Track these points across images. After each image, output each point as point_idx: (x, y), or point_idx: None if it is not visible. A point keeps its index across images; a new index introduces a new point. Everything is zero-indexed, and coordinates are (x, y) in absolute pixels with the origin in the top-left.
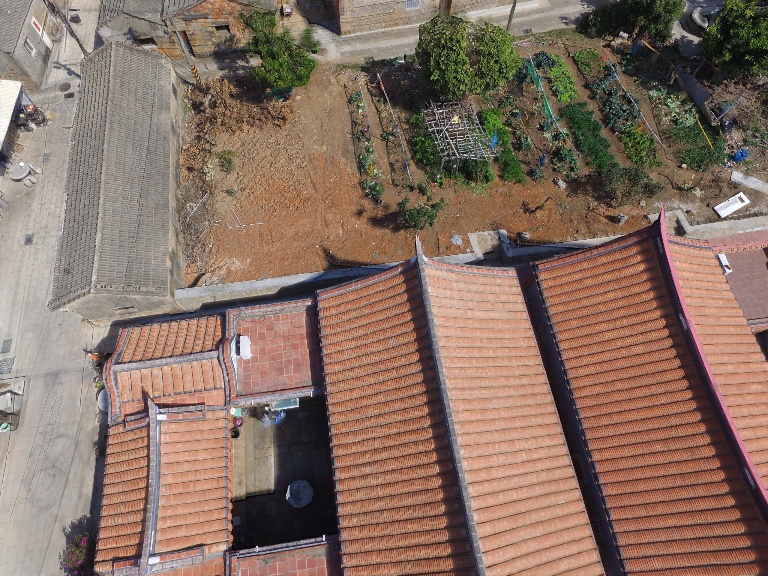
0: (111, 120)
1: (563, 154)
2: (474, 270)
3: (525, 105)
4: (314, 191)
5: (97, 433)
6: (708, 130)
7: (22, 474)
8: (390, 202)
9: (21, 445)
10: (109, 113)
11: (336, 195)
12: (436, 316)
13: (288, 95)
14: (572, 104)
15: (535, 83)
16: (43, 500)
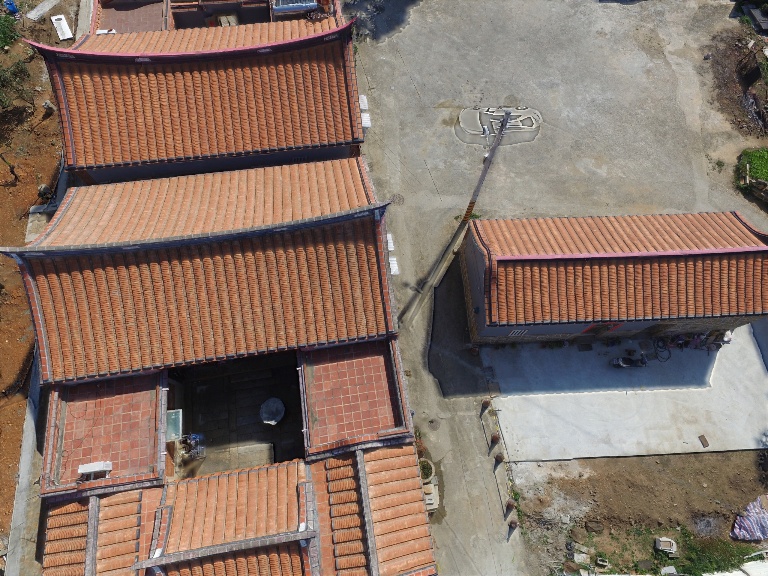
0: None
1: None
2: (56, 217)
3: None
4: None
5: None
6: None
7: None
8: None
9: None
10: None
11: None
12: None
13: None
14: None
15: None
16: None
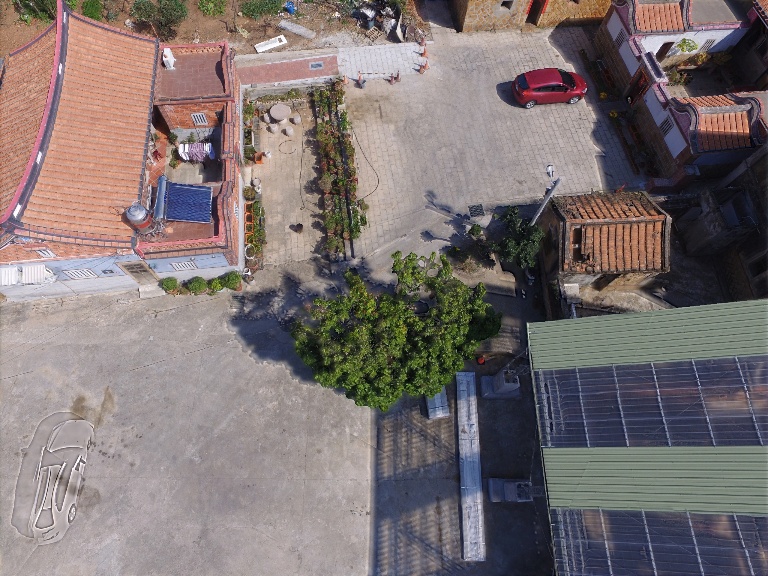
0: None
1: None
2: None
3: None
4: None
5: None
6: None
7: None
8: None
9: None
10: None
11: None
12: None
13: None
14: None
15: None
16: None
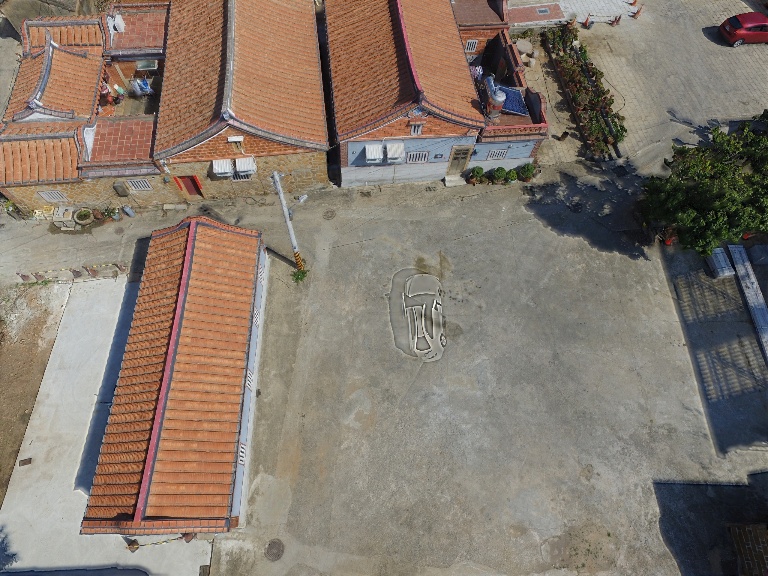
0: None
1: None
2: None
3: None
4: None
5: None
6: None
7: None
8: None
9: None
10: None
11: None
12: None
13: None
14: None
15: None
16: None
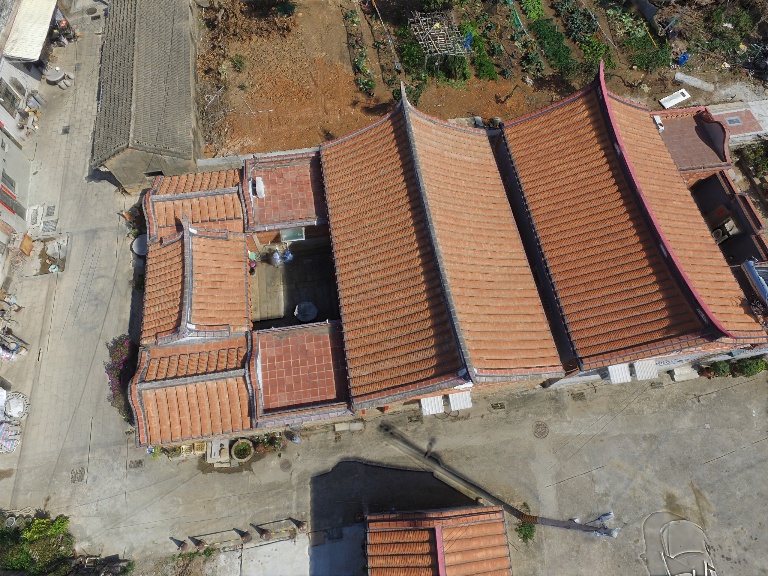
0: (140, 21)
1: (530, 57)
2: (450, 124)
3: (499, 21)
4: (315, 87)
5: (132, 274)
6: (656, 39)
7: (69, 304)
8: (381, 95)
9: (67, 283)
10: (138, 15)
11: (334, 90)
12: (418, 148)
13: (291, 12)
14: (539, 19)
15: (507, 0)
16: (88, 323)
